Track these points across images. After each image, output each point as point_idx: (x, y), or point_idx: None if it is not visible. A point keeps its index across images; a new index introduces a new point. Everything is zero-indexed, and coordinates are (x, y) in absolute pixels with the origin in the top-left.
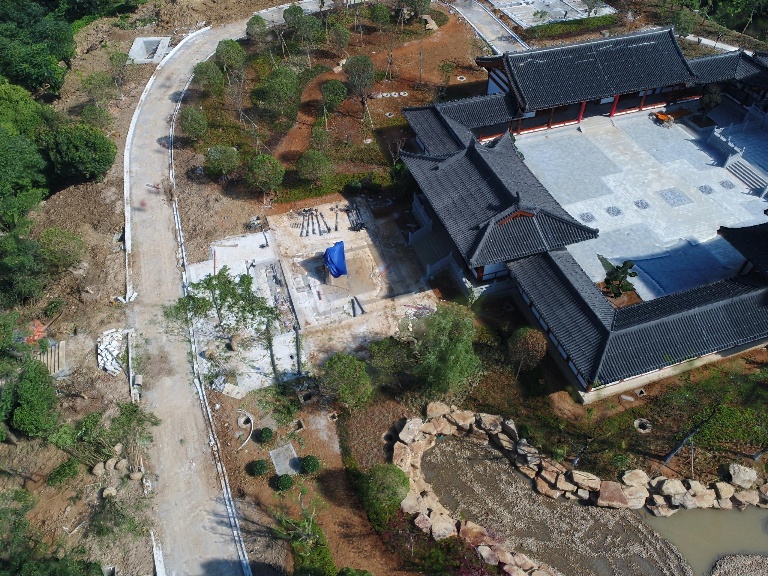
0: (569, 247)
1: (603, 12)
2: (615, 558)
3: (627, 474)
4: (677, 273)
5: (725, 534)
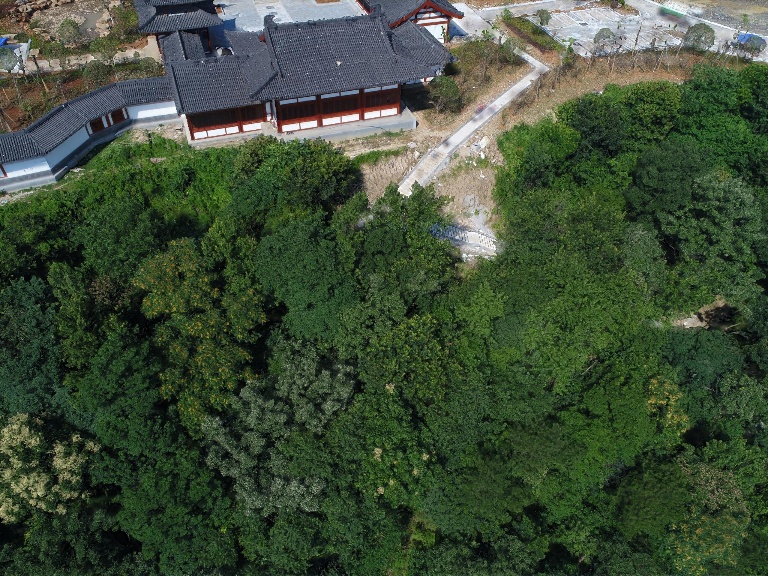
0: (251, 7)
1: (578, 51)
2: (99, 4)
3: (122, 1)
4: (222, 27)
5: (94, 21)
